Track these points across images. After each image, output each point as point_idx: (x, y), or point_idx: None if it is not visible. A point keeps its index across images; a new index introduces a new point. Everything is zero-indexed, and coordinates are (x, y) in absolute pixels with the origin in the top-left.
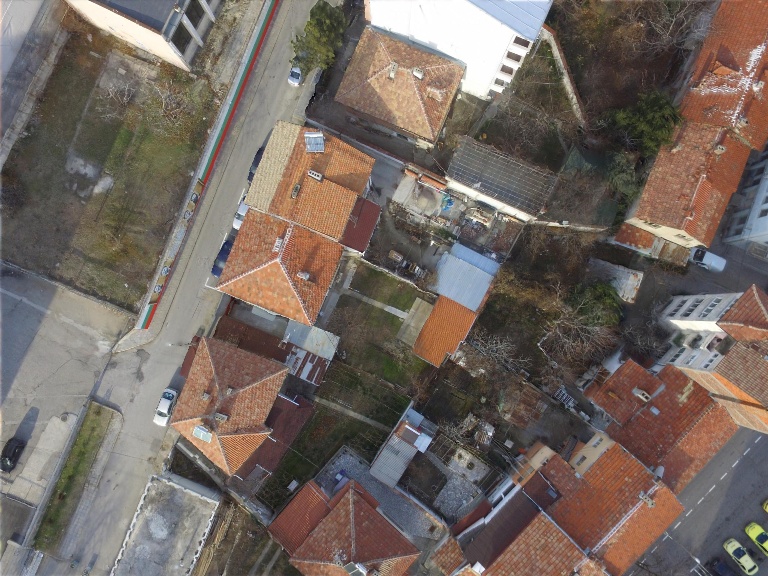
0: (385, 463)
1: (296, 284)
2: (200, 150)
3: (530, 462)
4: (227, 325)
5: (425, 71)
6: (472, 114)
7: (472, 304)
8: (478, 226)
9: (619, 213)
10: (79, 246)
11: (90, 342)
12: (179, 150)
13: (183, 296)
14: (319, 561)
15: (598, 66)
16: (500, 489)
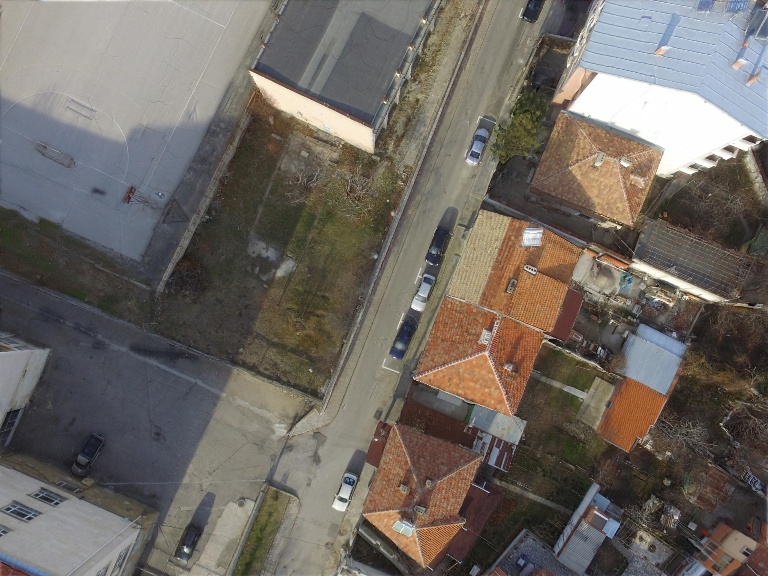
0: (574, 550)
1: (501, 375)
2: (383, 232)
3: (722, 548)
4: (412, 410)
5: None
6: (650, 191)
7: (661, 387)
8: (658, 304)
9: None
10: (262, 331)
11: (266, 425)
12: (363, 233)
13: (360, 377)
14: None
15: None
16: (690, 575)
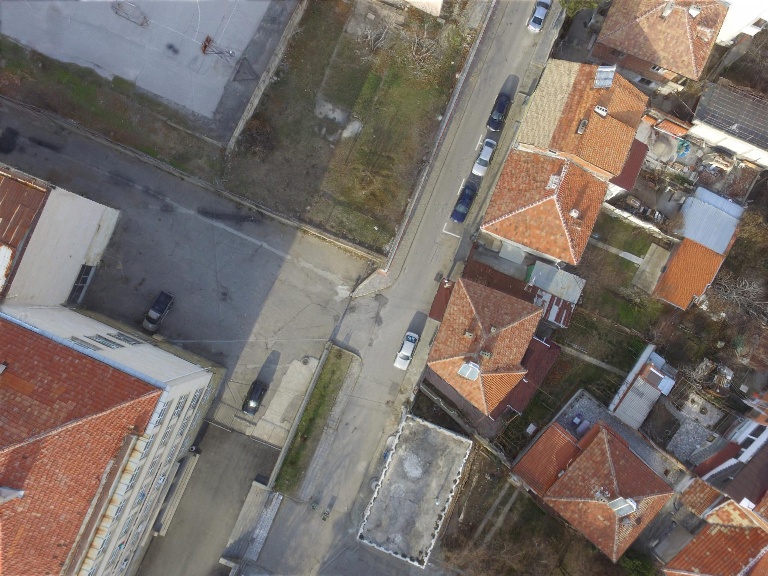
0: (630, 405)
1: (567, 222)
2: (448, 94)
3: None
4: (475, 268)
5: None
6: (709, 60)
7: (718, 247)
8: (715, 172)
9: None
10: (328, 189)
11: (330, 287)
12: (427, 94)
13: (421, 241)
14: (578, 499)
15: None
16: (743, 432)
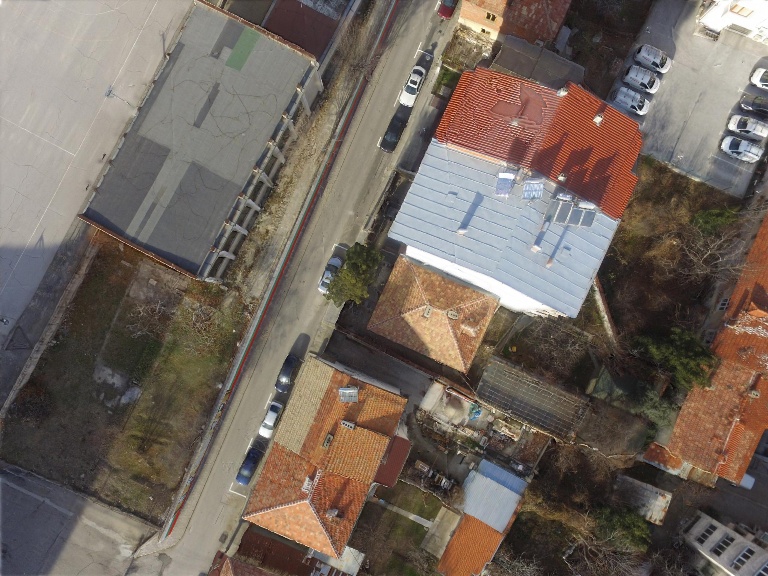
0: None
1: (324, 521)
2: (229, 362)
3: None
4: (251, 540)
5: (459, 310)
6: (502, 324)
7: (499, 525)
8: (505, 437)
9: (649, 437)
10: (105, 457)
11: (112, 546)
12: (208, 362)
13: (207, 501)
14: None
15: (631, 289)
16: None
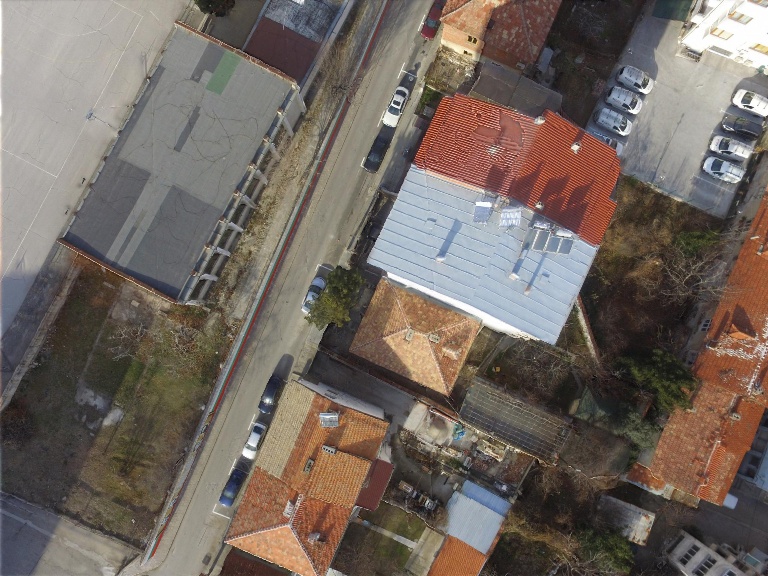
0: None
1: (306, 545)
2: (212, 384)
3: None
4: (234, 562)
5: (441, 333)
6: (486, 344)
7: (482, 546)
8: (489, 457)
9: (632, 458)
10: (87, 479)
11: (94, 568)
12: (190, 384)
13: (190, 522)
14: None
15: (613, 310)
16: None
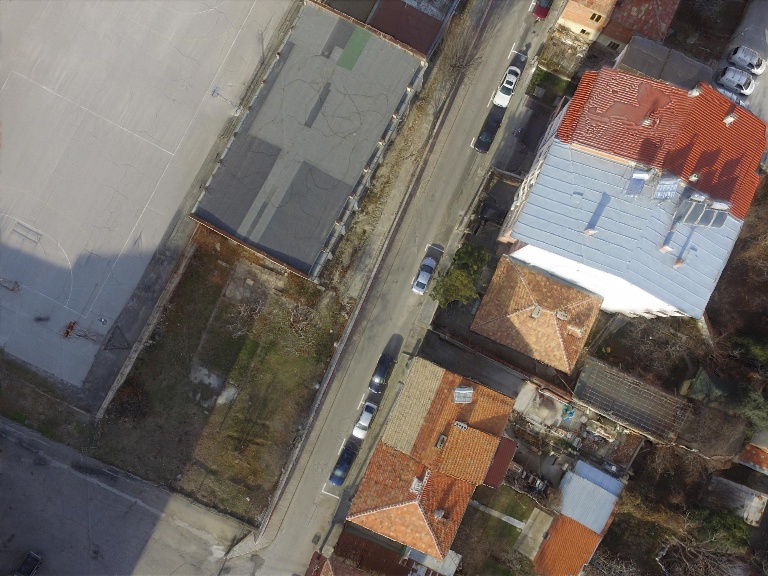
0: None
1: (431, 522)
2: (326, 362)
3: None
4: (348, 541)
5: (567, 311)
6: (595, 325)
7: (596, 526)
8: (599, 438)
9: (747, 438)
10: (201, 457)
11: (204, 547)
12: (305, 362)
13: (299, 501)
14: None
15: (729, 291)
16: None
